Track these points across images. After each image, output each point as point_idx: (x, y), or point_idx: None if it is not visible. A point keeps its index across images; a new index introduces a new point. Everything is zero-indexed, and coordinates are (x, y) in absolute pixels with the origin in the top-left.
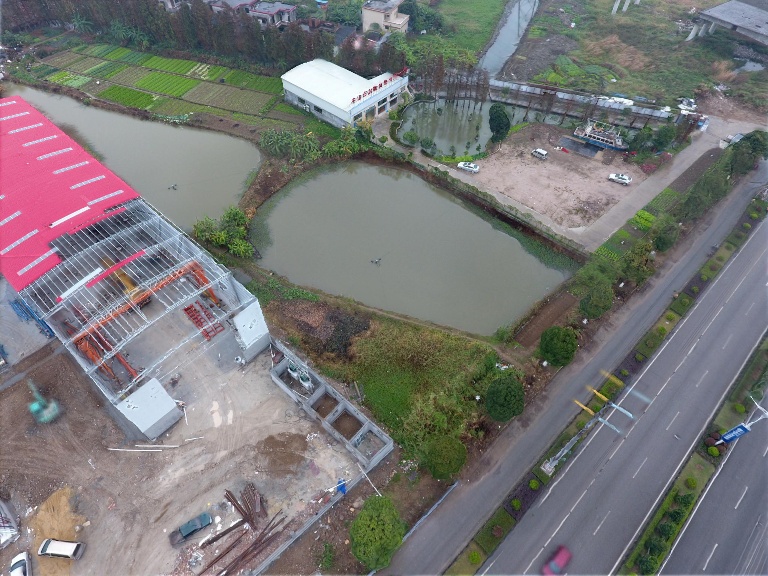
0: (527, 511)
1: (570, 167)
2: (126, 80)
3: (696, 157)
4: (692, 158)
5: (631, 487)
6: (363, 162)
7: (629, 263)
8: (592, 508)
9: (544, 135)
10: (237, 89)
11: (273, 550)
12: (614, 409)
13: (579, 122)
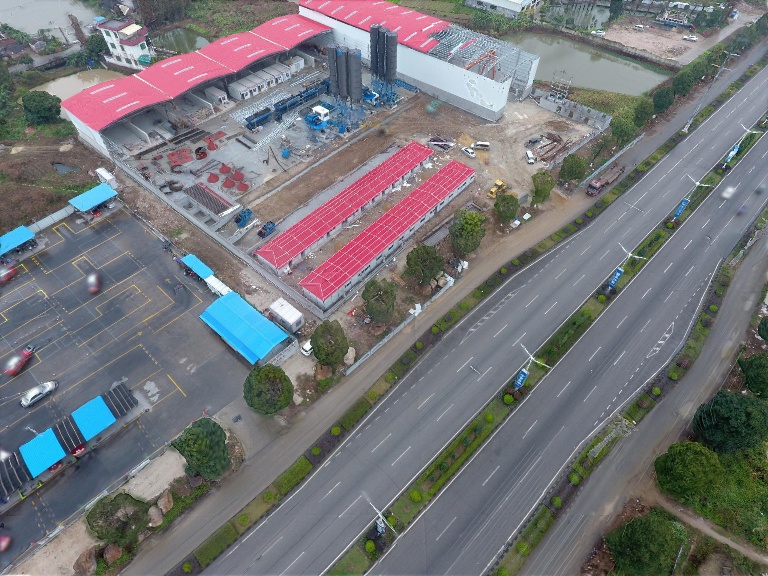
0: (679, 143)
1: (658, 34)
2: None
3: (733, 30)
4: (731, 31)
5: (725, 138)
6: (532, 33)
7: (710, 58)
8: (708, 143)
9: (637, 21)
10: (430, 0)
11: None
12: (710, 117)
13: None
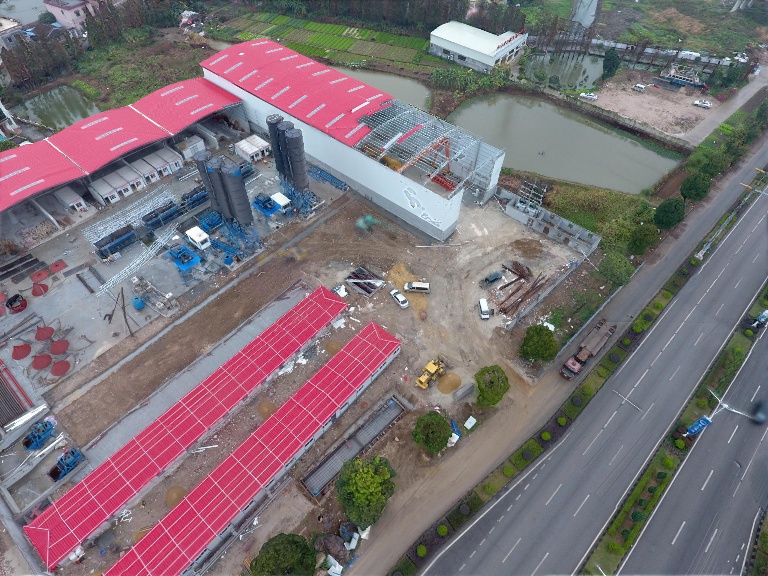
0: (691, 277)
1: (663, 97)
2: (298, 38)
3: (755, 91)
4: (752, 92)
5: (753, 267)
6: (507, 94)
7: (731, 144)
8: (731, 276)
9: (637, 77)
10: (388, 45)
11: (543, 291)
12: (732, 231)
13: (661, 68)
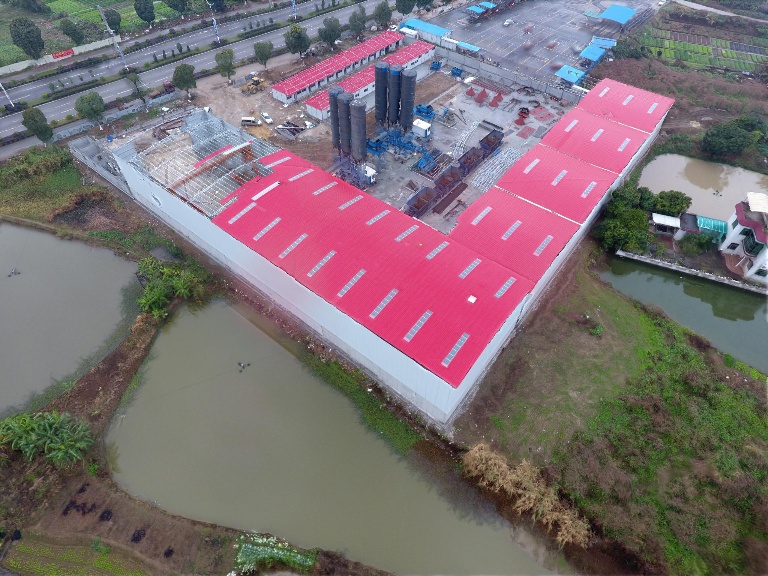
0: None
1: None
2: None
3: None
4: None
5: None
6: None
7: None
8: None
9: None
10: None
11: None
12: None
13: None
